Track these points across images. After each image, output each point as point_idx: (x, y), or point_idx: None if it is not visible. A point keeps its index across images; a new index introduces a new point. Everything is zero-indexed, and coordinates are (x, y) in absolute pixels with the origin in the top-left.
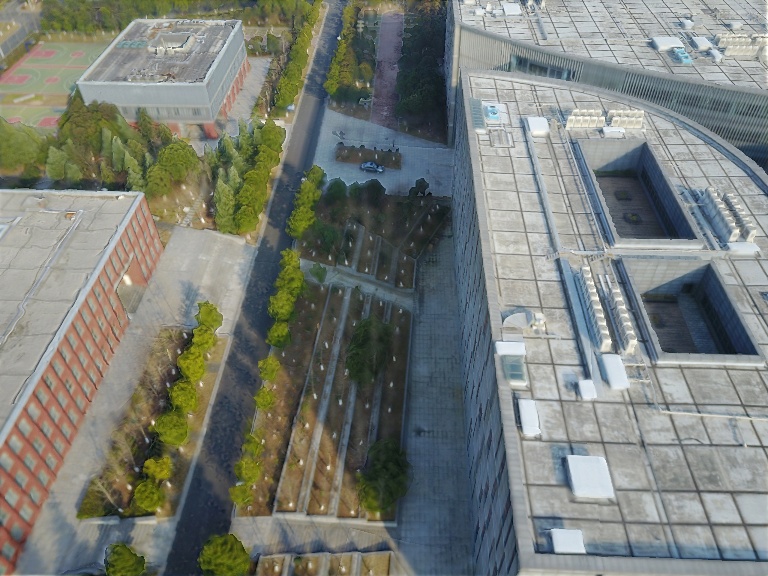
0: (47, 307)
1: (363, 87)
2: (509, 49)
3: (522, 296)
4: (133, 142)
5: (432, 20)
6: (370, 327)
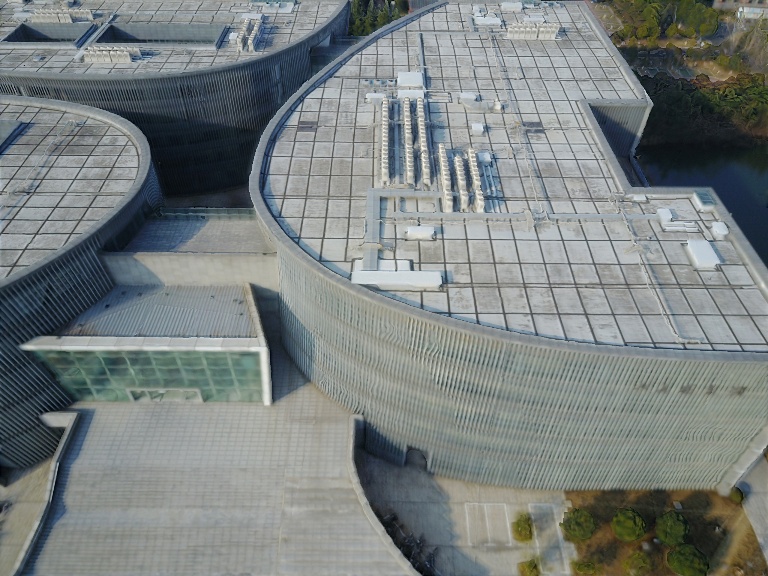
0: None
1: None
2: None
3: (88, 6)
4: None
5: None
6: None
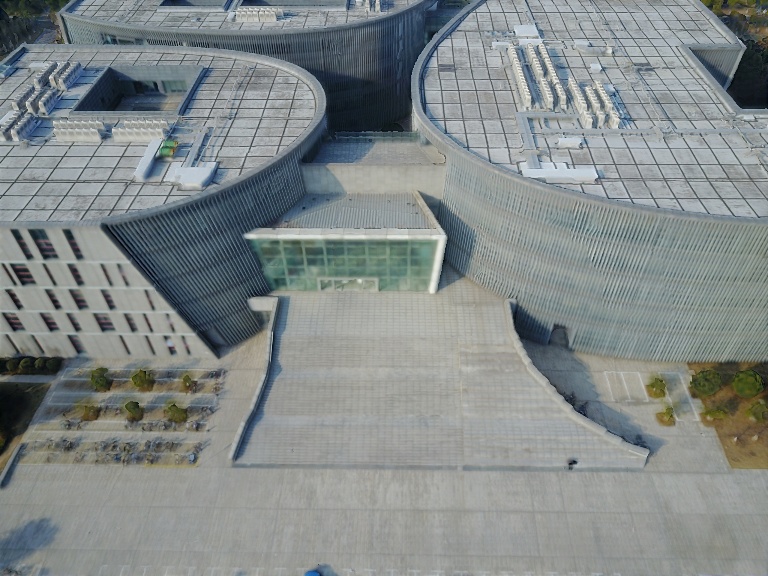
0: None
1: None
2: None
3: None
4: None
5: None
6: None
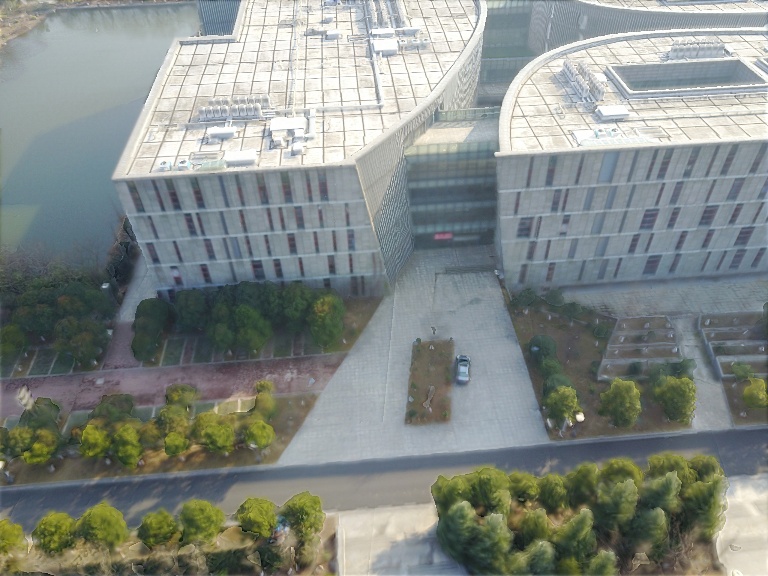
0: None
1: (261, 385)
2: (402, 135)
3: None
4: None
5: None
6: None
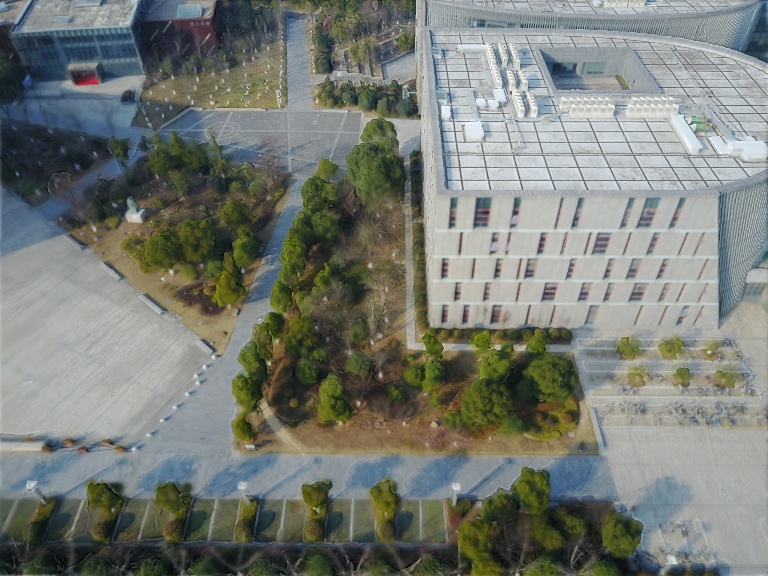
0: None
1: None
2: None
3: None
4: None
5: None
6: None
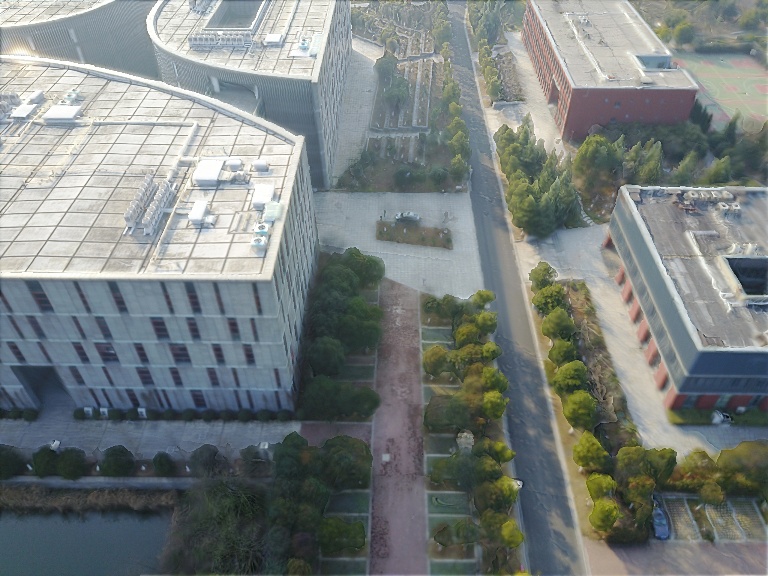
0: (569, 44)
1: (434, 300)
2: None
3: None
4: (651, 161)
5: (288, 545)
6: (397, 90)
